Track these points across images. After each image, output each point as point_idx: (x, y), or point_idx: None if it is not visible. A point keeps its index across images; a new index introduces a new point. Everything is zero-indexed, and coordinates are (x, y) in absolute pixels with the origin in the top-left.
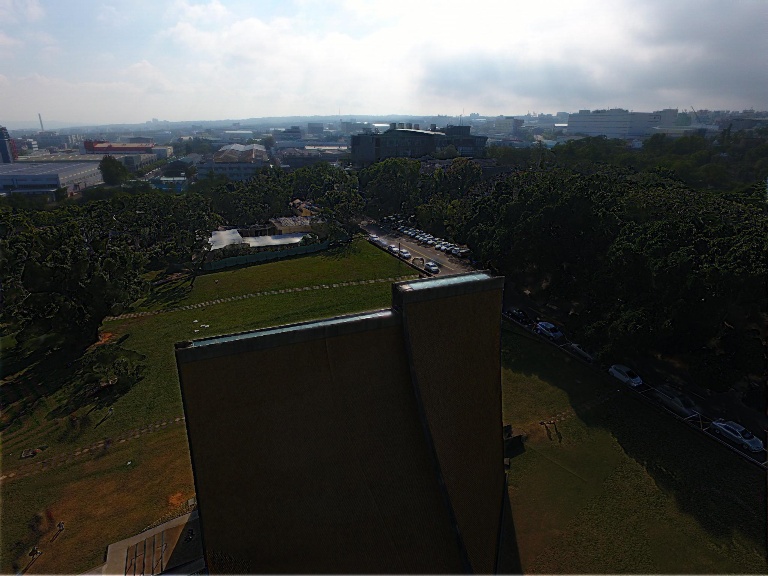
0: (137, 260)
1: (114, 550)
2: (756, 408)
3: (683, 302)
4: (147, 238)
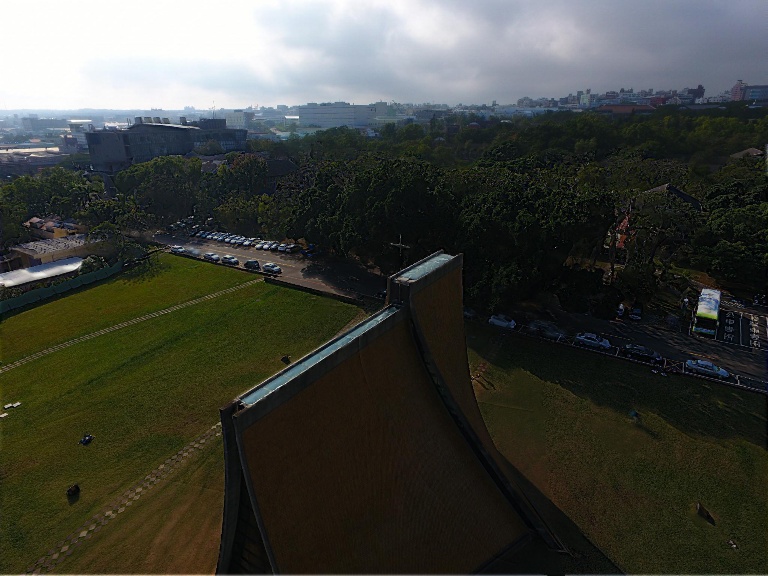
0: None
1: None
2: (603, 318)
3: (543, 252)
4: None
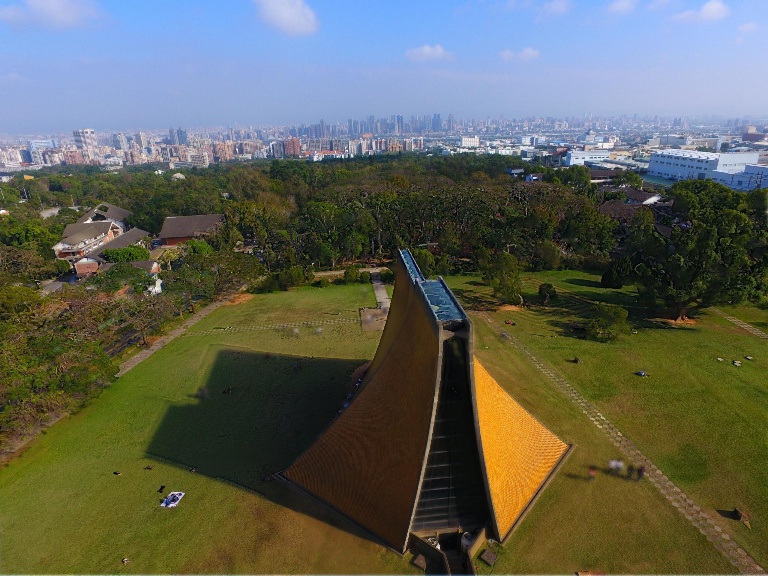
0: None
1: None
2: None
3: None
4: None
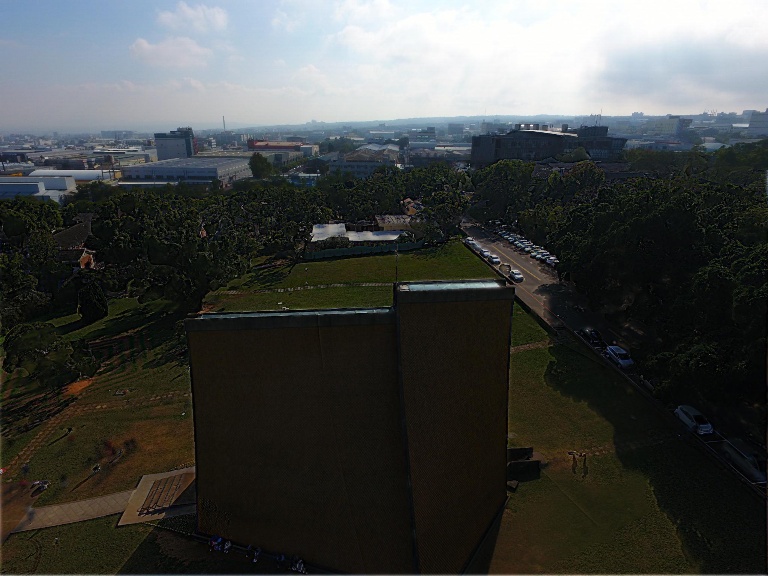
0: (250, 245)
1: (145, 480)
2: None
3: (764, 342)
4: (268, 226)
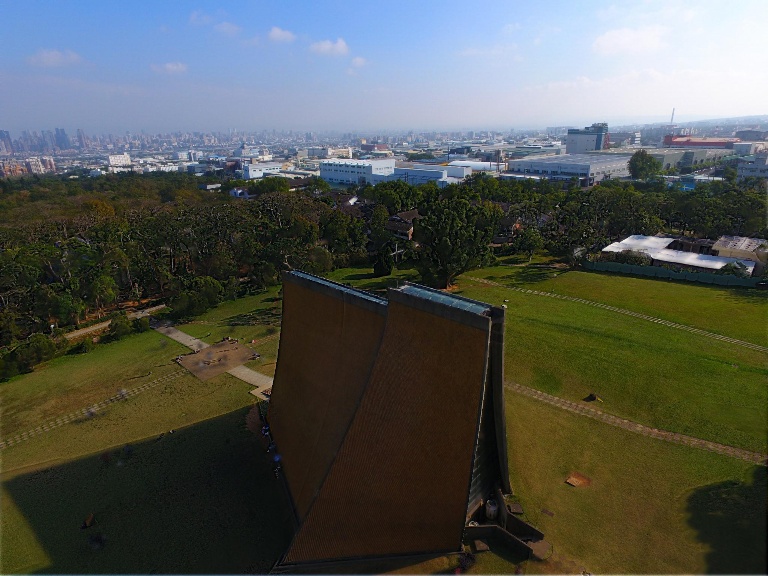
0: (534, 242)
1: None
2: None
3: None
4: None
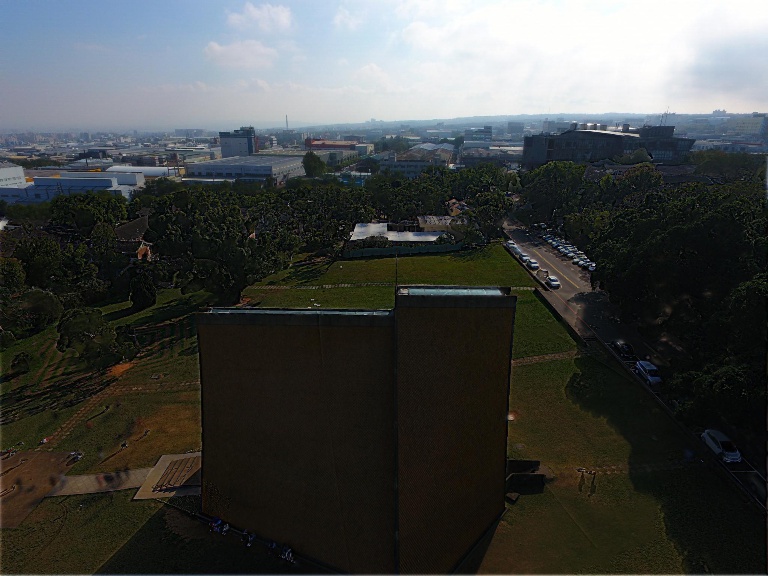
0: (292, 242)
1: (163, 459)
2: None
3: None
4: (313, 224)
